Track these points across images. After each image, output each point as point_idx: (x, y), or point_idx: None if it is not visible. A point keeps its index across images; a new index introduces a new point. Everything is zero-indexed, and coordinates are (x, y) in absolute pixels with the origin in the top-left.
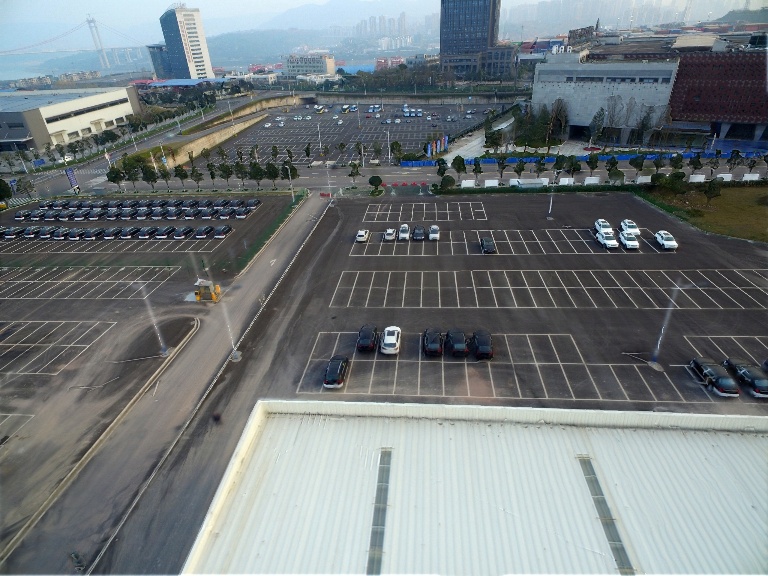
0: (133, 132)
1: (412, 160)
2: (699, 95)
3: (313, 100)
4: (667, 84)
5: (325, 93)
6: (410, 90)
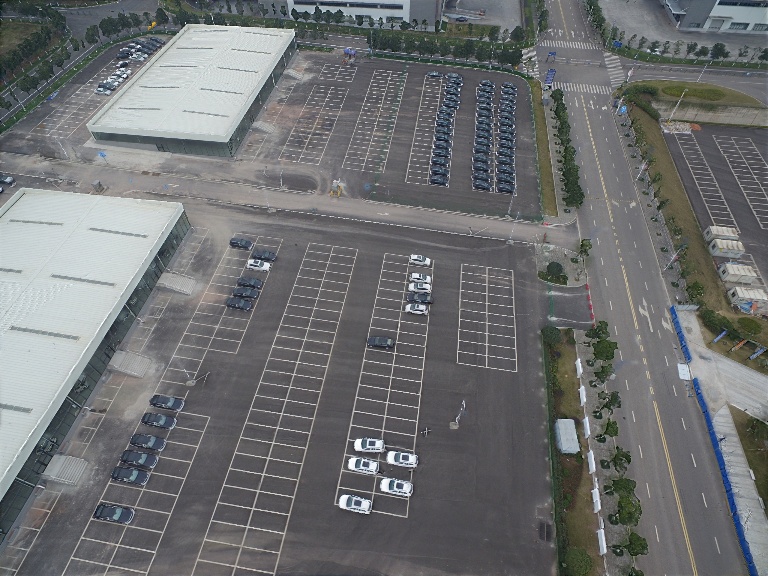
0: (760, 58)
1: (706, 323)
2: None
3: None
4: None
5: None
6: None
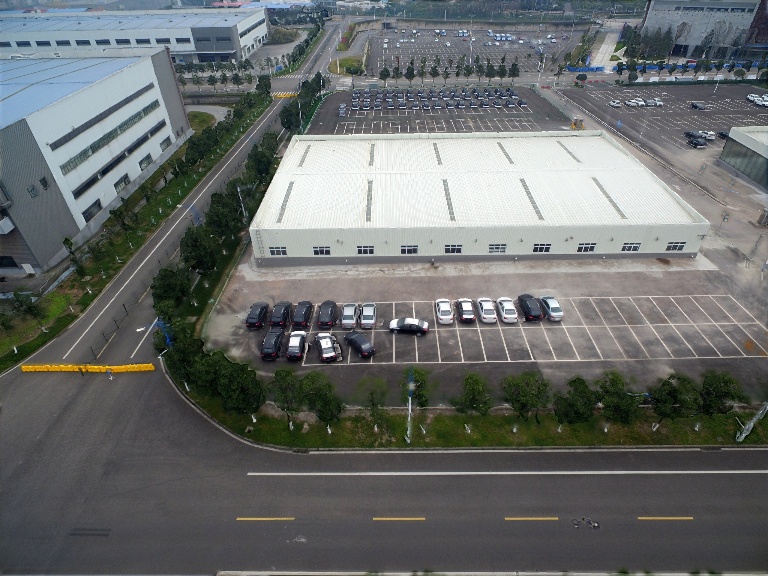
0: None
1: None
2: (765, 22)
3: (389, 25)
4: (751, 13)
5: (406, 19)
6: (483, 17)
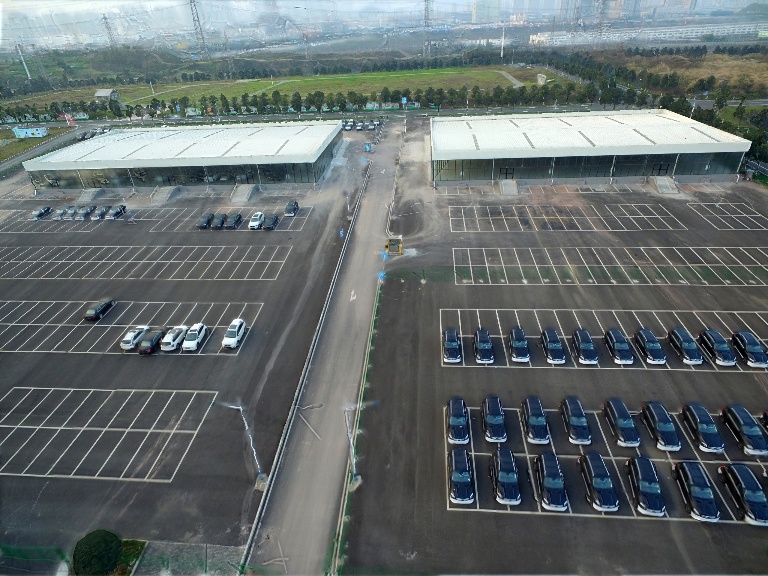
0: None
1: None
2: None
3: None
4: None
5: None
6: None
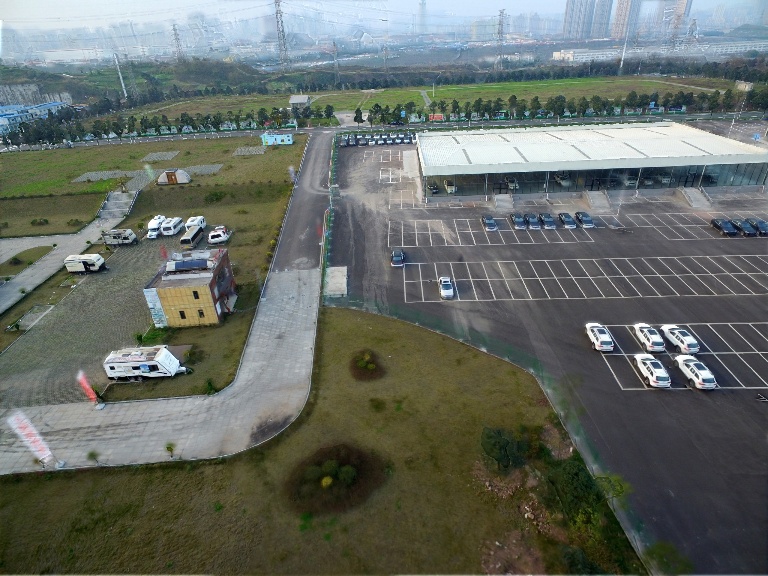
0: None
1: None
2: None
3: None
4: None
5: None
6: None
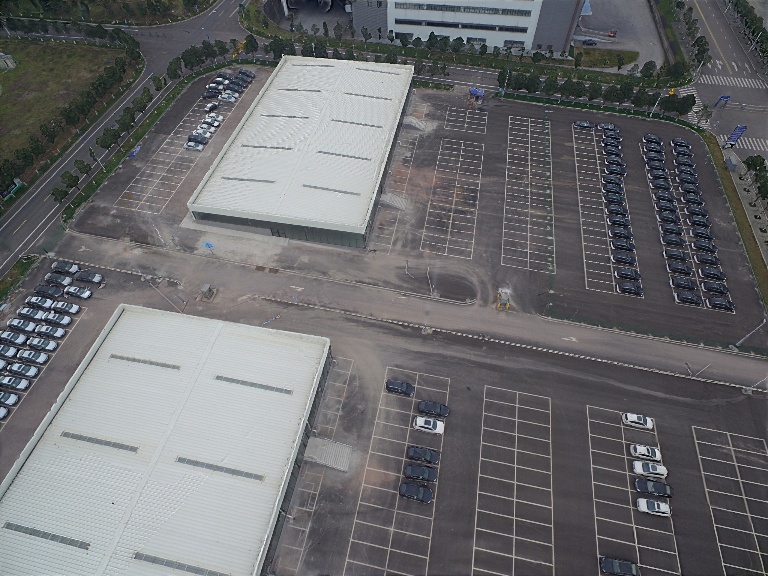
0: None
1: None
2: None
3: None
4: None
5: None
6: None
